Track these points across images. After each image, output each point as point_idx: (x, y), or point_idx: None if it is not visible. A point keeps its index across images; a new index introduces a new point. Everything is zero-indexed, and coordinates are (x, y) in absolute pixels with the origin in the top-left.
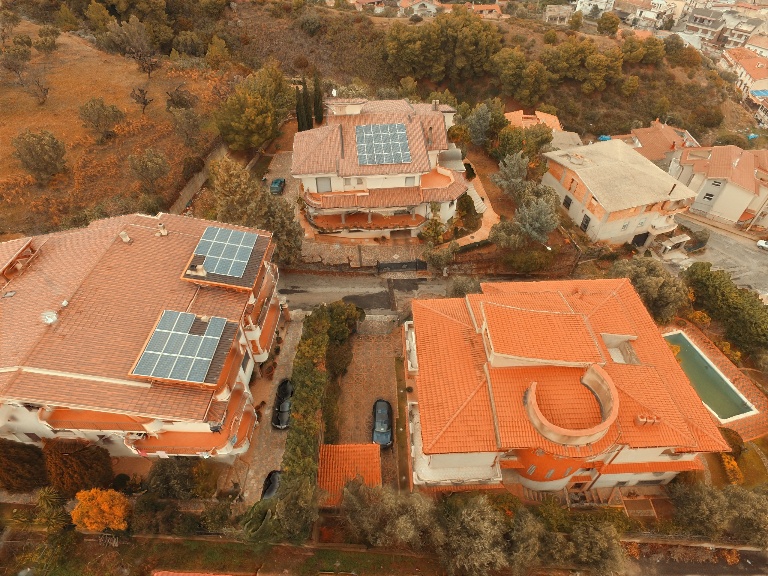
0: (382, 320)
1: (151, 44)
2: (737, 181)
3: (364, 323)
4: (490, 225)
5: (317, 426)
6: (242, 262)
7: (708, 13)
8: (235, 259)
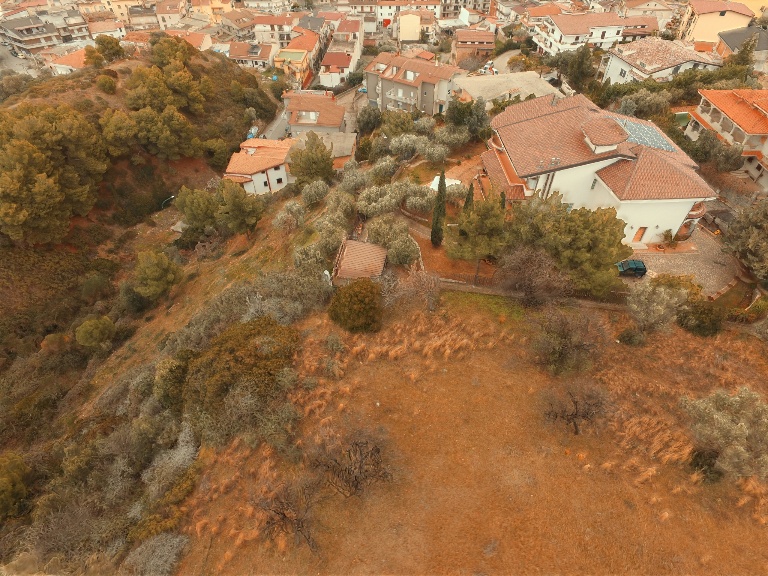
0: None
1: None
2: (460, 70)
3: None
4: None
5: None
6: None
7: (24, 22)
8: None
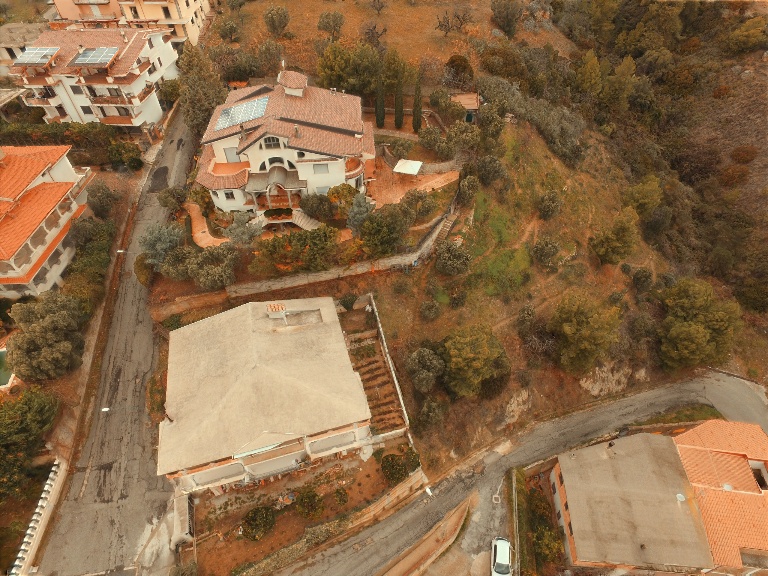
0: (138, 185)
1: (628, 45)
2: None
3: (139, 177)
4: (214, 244)
5: (29, 131)
6: (86, 61)
7: None
8: (89, 59)
